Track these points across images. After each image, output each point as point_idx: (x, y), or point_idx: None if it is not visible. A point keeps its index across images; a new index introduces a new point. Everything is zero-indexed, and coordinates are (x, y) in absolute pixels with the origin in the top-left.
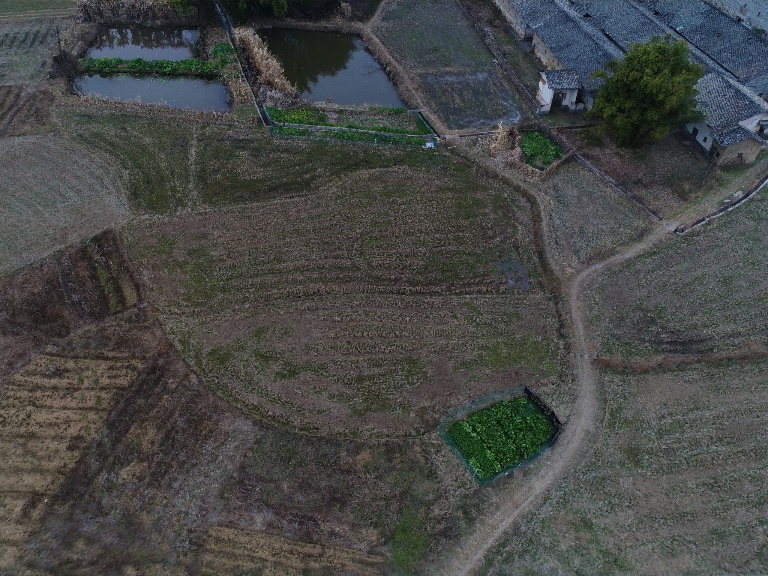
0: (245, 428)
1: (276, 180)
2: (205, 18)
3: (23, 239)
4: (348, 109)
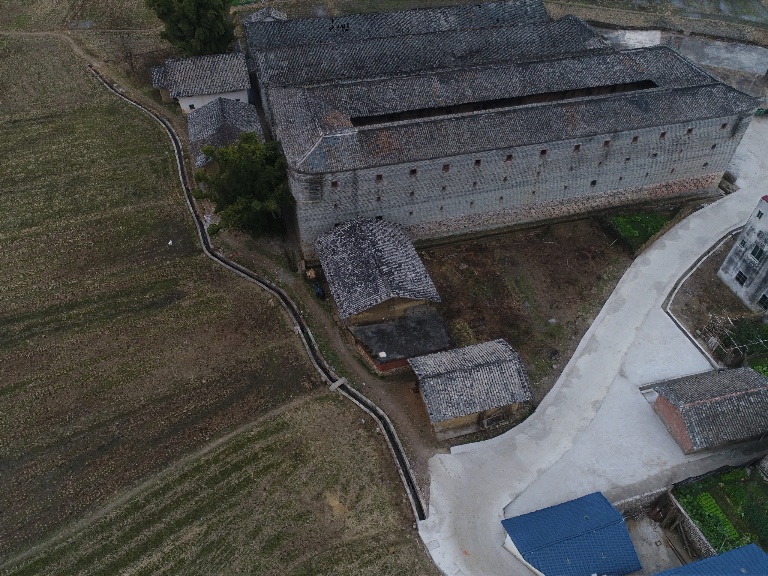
0: None
1: None
2: None
3: None
4: None
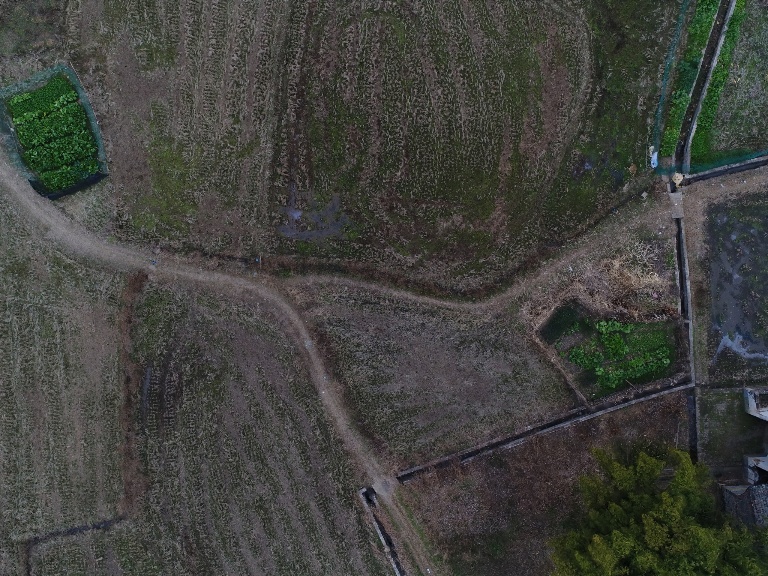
0: None
1: None
2: None
3: None
4: None
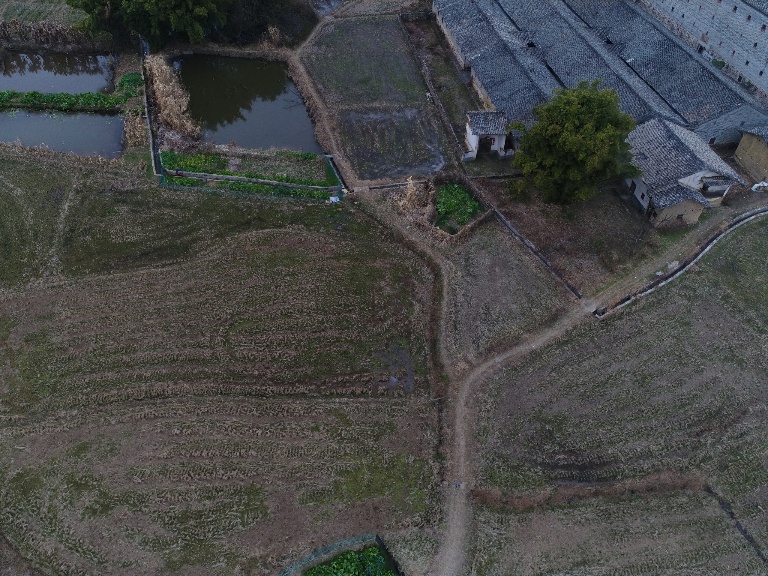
0: None
1: (151, 243)
2: (117, 44)
3: None
4: (252, 154)
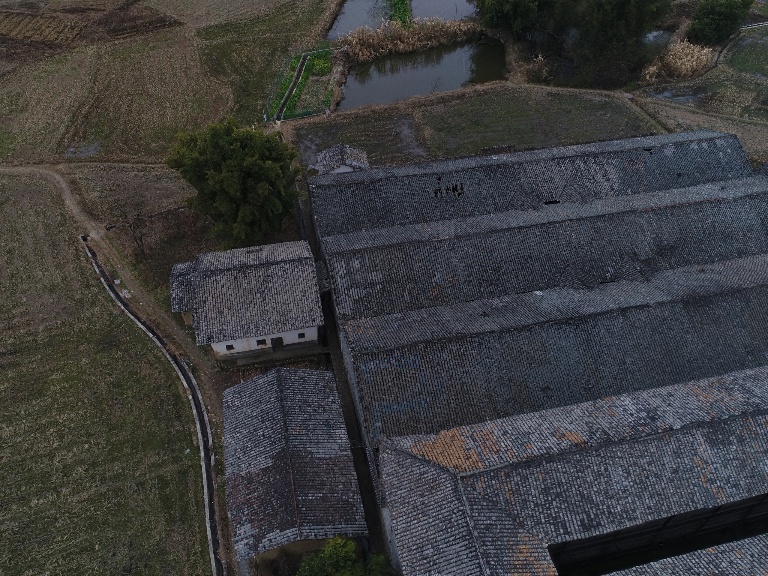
0: (7, 69)
1: None
2: None
3: (184, 7)
4: (331, 81)
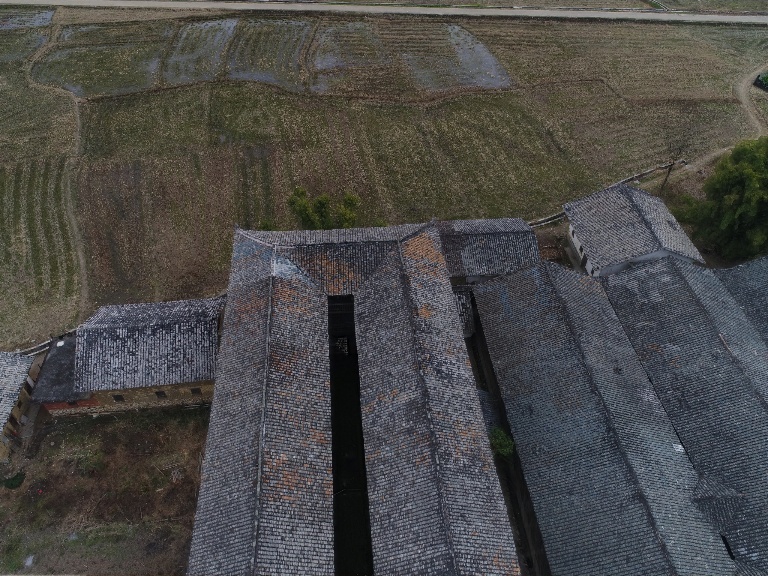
0: None
1: None
2: None
3: None
4: None
